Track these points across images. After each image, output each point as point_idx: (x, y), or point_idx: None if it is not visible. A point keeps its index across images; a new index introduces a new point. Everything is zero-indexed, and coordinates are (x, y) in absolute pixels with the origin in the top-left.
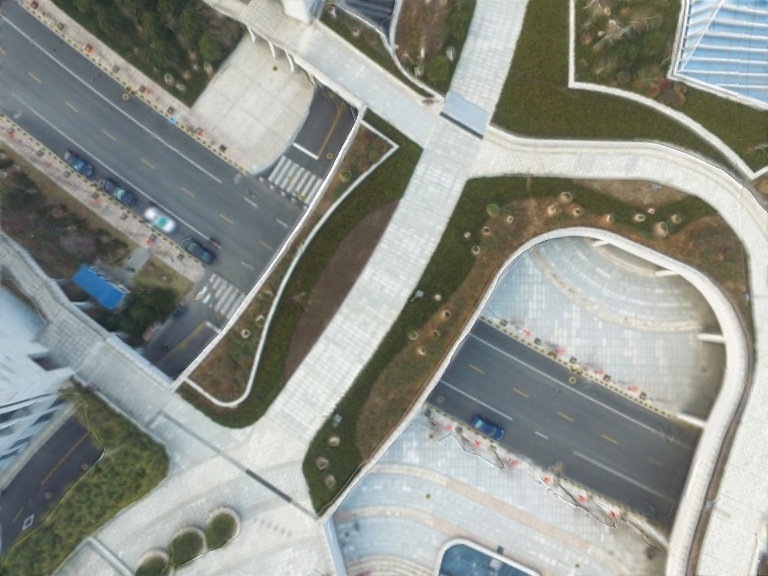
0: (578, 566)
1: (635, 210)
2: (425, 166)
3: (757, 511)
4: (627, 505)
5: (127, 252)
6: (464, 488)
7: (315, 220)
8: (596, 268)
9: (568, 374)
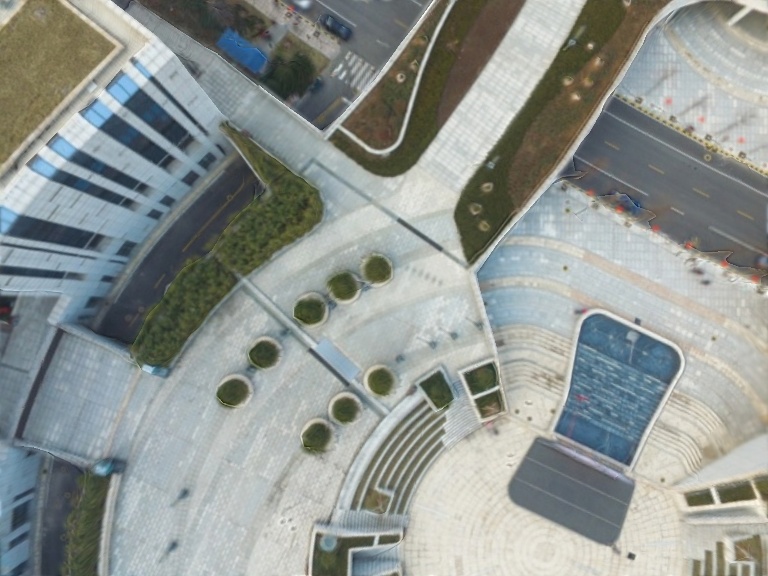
0: (714, 339)
1: None
2: None
3: None
4: (764, 278)
5: (264, 27)
6: (601, 261)
7: None
8: (731, 47)
9: (703, 151)
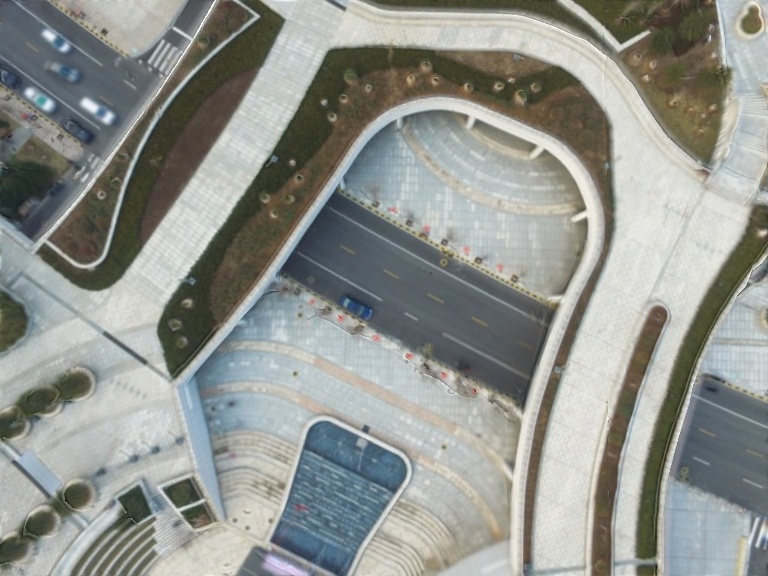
0: (445, 447)
1: (496, 80)
2: (287, 37)
3: (609, 379)
4: (495, 387)
5: (8, 131)
6: (331, 367)
7: (173, 86)
8: (470, 151)
9: (439, 256)
